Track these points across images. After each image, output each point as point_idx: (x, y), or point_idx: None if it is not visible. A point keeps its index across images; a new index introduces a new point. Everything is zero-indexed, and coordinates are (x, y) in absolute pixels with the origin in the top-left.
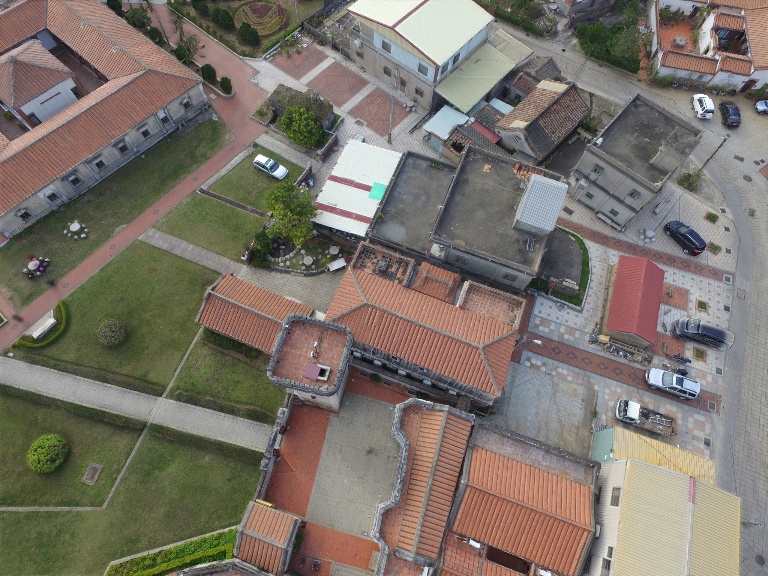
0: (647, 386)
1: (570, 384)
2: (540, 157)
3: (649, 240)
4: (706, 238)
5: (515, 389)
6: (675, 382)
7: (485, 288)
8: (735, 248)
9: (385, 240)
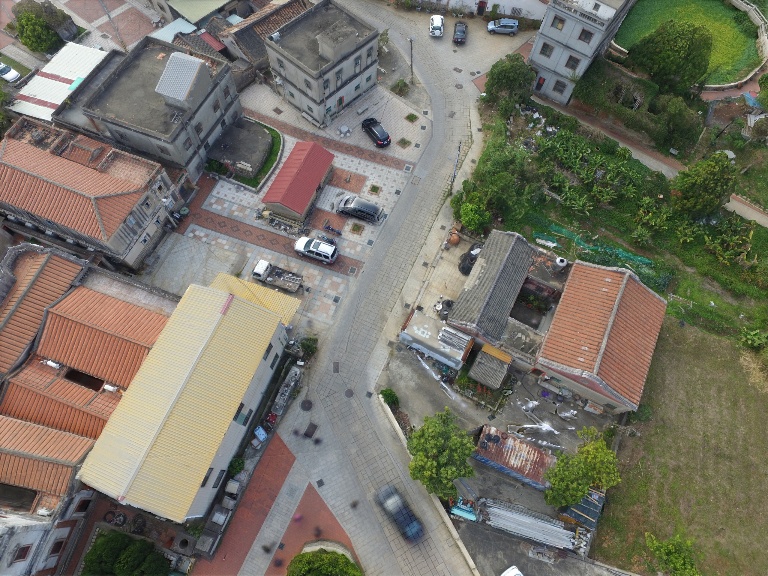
0: (297, 254)
1: (225, 252)
2: (252, 61)
3: (345, 136)
4: (400, 135)
5: (171, 255)
6: (312, 246)
7: (126, 154)
8: (425, 143)
9: (65, 122)
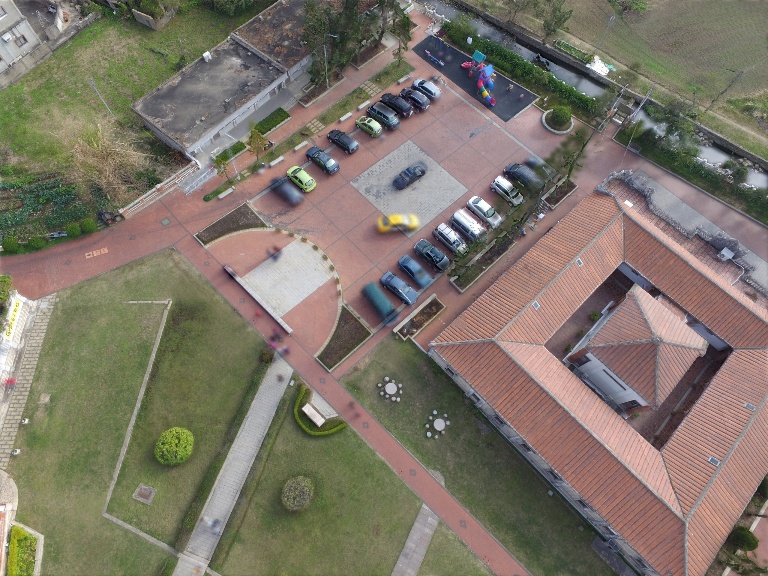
0: None
1: None
2: None
3: None
4: None
5: None
6: None
7: None
8: None
9: None
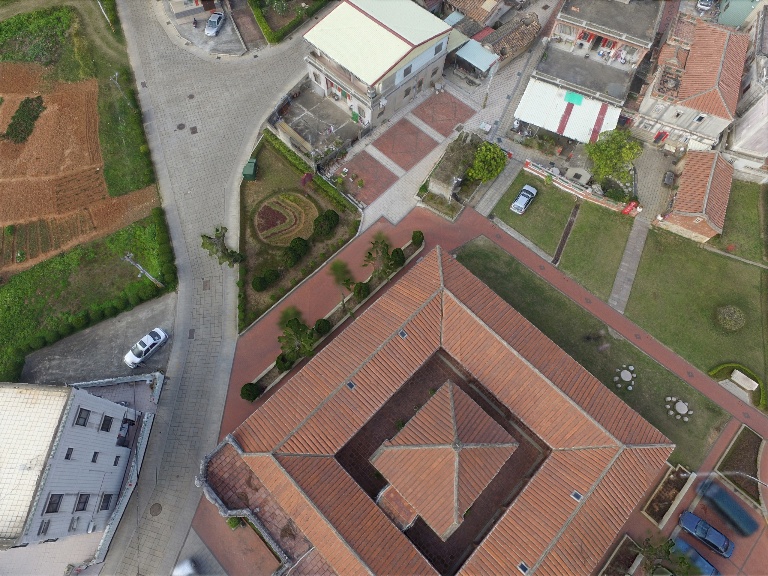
0: None
1: None
2: (513, 3)
3: None
4: None
5: None
6: None
7: None
8: None
9: None
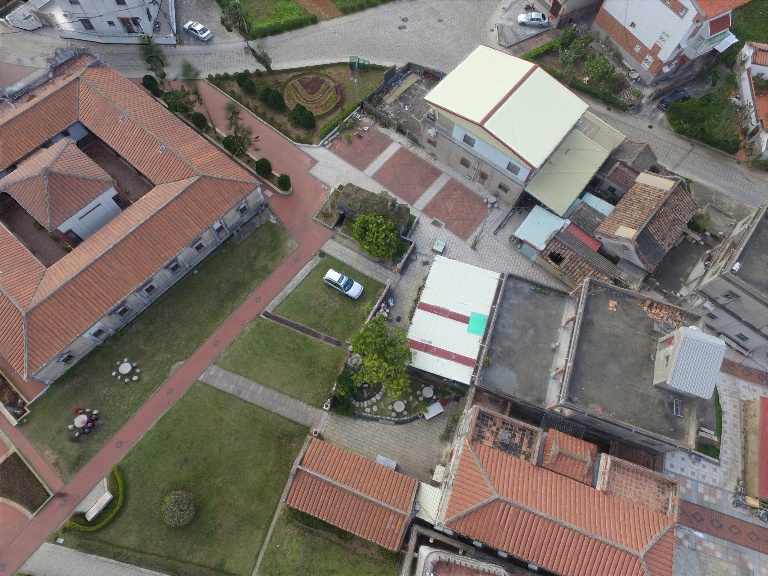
0: None
1: (720, 562)
2: (652, 270)
3: None
4: None
5: None
6: None
7: (630, 466)
8: None
9: (495, 391)
